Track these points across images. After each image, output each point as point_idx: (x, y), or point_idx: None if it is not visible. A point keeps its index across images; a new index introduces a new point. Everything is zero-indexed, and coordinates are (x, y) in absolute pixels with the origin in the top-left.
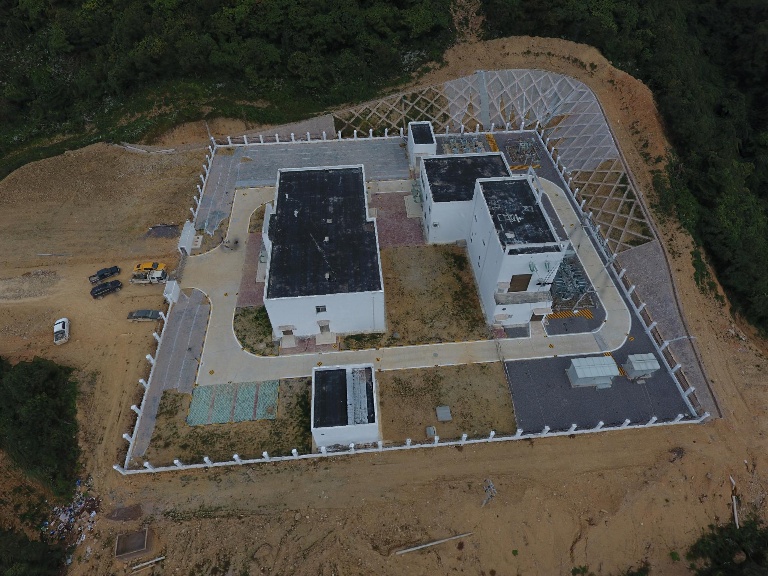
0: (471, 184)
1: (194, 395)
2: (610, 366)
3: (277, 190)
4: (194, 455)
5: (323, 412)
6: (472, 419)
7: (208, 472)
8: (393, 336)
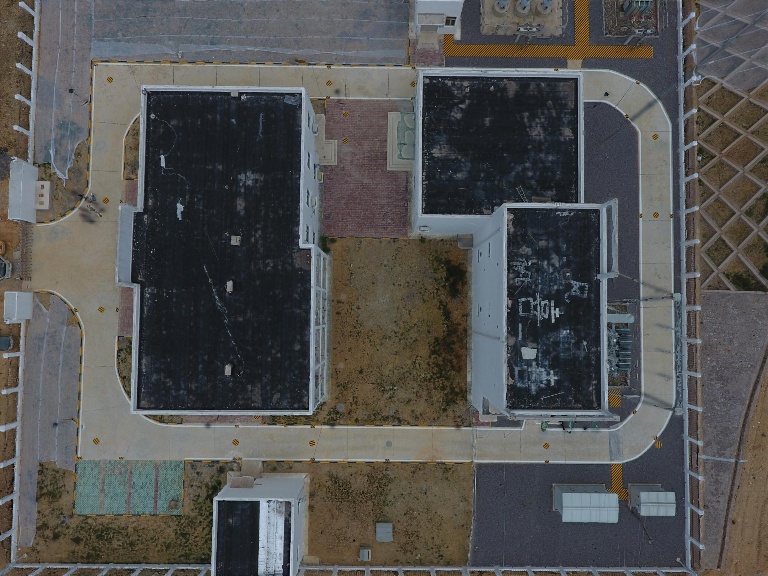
0: (500, 161)
1: (78, 473)
2: (610, 510)
3: (142, 149)
4: (89, 551)
5: (228, 555)
6: (418, 540)
7: (108, 571)
8: (336, 409)
